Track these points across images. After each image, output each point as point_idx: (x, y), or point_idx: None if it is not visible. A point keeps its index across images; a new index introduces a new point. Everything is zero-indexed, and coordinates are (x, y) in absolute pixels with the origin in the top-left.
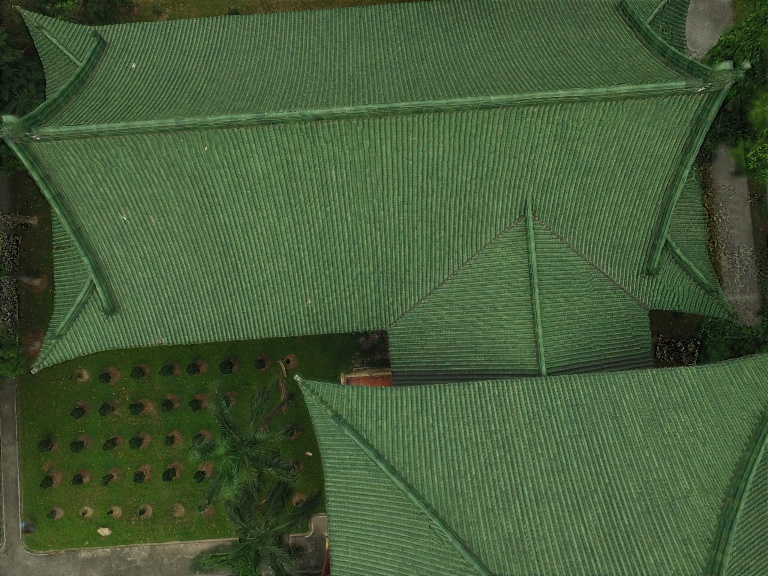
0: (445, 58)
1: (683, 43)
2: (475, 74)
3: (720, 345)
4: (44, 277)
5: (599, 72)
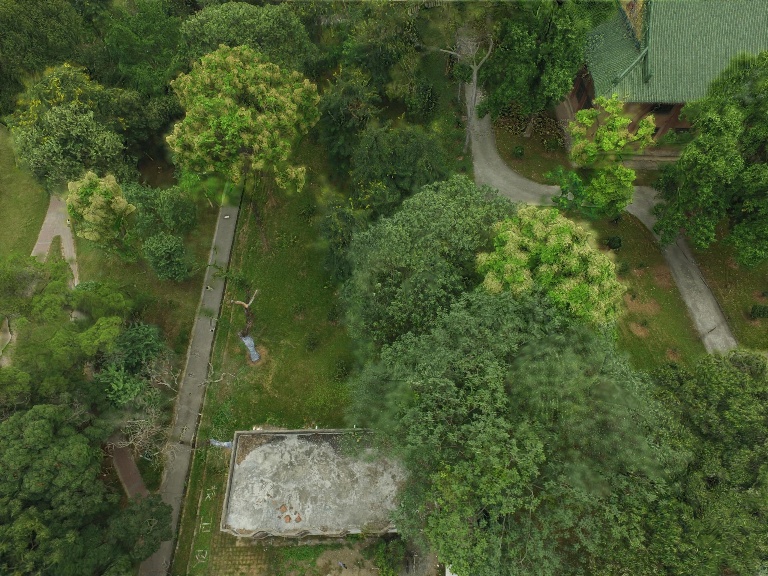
0: (760, 43)
1: (596, 75)
2: (750, 18)
3: (536, 3)
4: None
5: (689, 6)
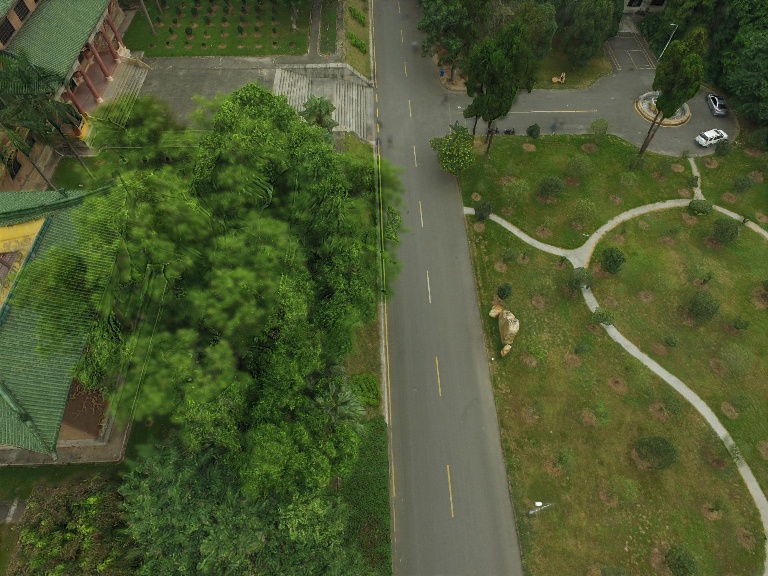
0: None
1: None
2: None
3: None
4: (253, 303)
5: None
